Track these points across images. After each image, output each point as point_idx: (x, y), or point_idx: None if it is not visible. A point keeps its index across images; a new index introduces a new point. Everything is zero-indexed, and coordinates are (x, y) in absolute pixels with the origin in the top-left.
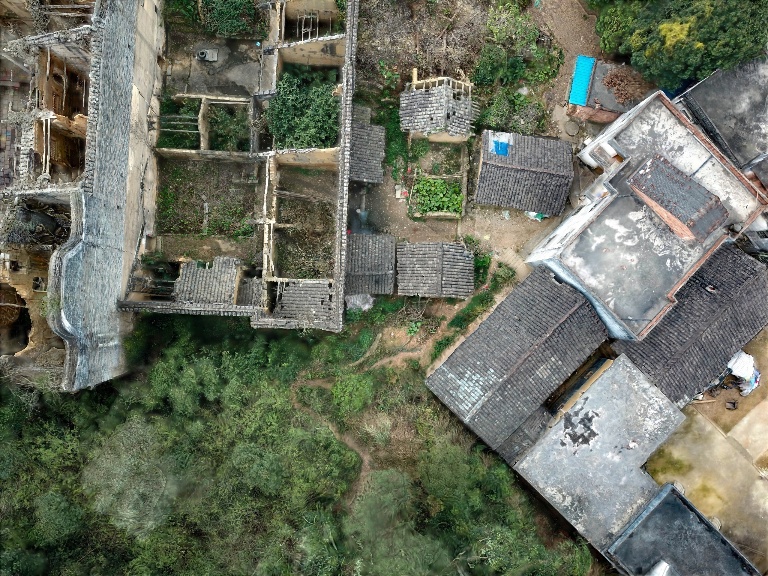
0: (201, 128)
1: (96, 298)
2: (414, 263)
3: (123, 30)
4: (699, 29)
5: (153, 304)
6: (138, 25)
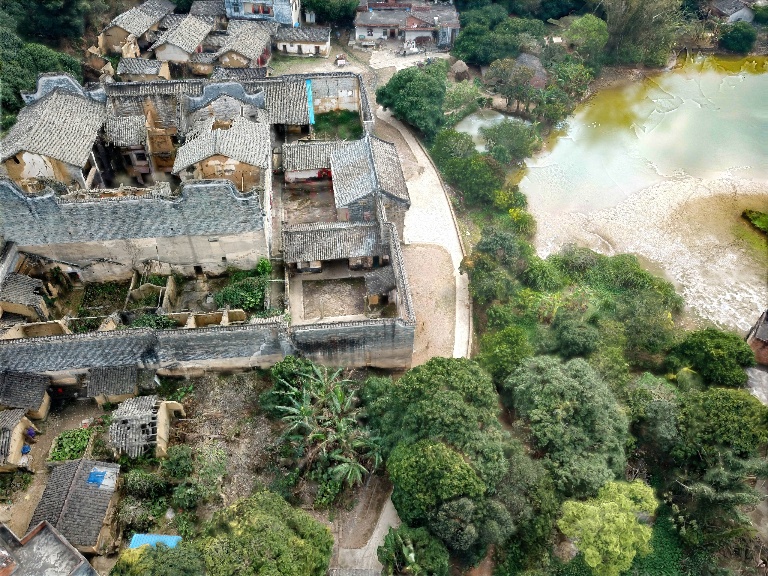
0: (143, 286)
1: (2, 218)
2: (4, 418)
3: (175, 221)
4: (131, 571)
5: (4, 256)
6: (194, 238)
